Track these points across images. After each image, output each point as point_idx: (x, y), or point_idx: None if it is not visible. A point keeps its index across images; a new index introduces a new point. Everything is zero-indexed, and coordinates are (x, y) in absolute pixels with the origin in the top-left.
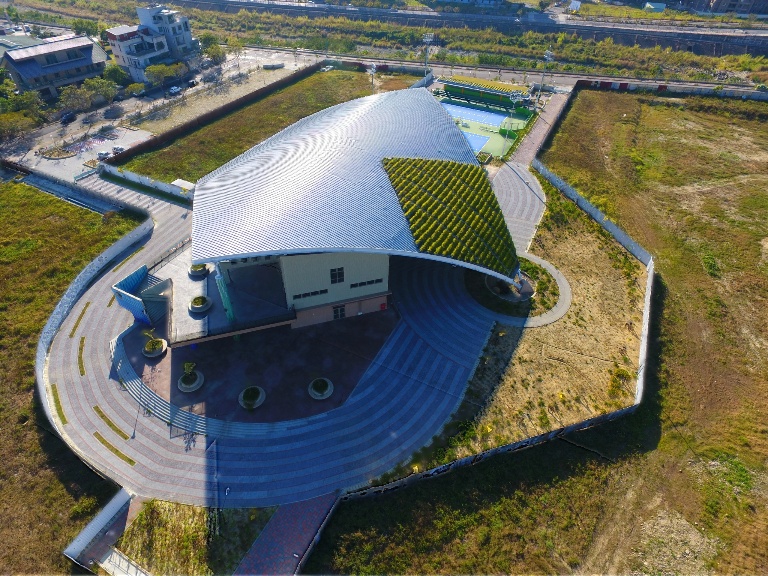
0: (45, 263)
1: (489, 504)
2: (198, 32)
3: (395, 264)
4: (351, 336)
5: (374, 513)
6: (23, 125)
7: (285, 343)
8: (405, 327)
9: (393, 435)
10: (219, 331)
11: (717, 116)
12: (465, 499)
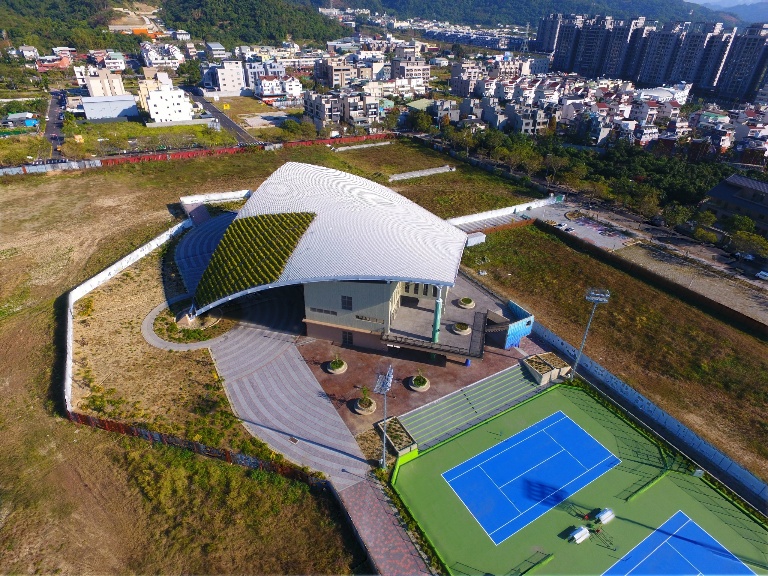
0: None
1: (137, 247)
2: None
3: None
4: None
5: None
6: None
7: None
8: None
9: None
10: None
11: None
12: None
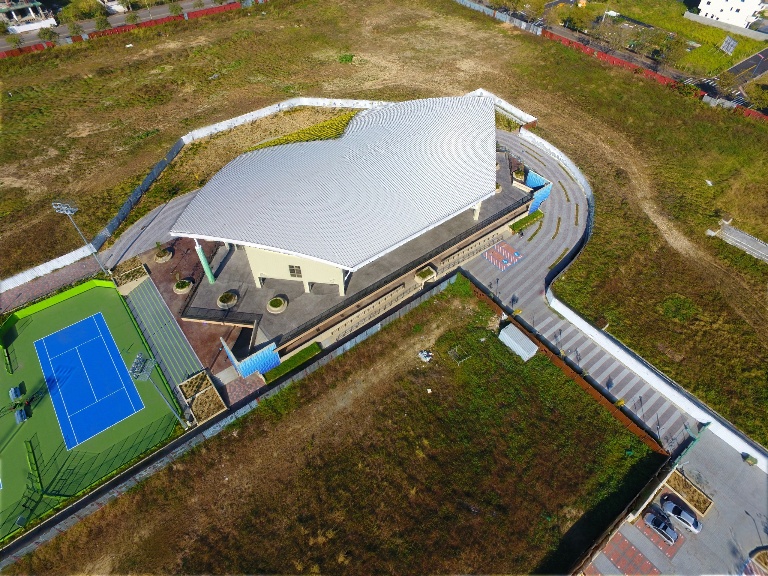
0: None
1: None
2: None
3: None
4: None
5: None
6: None
7: None
8: None
9: None
10: None
11: None
12: None
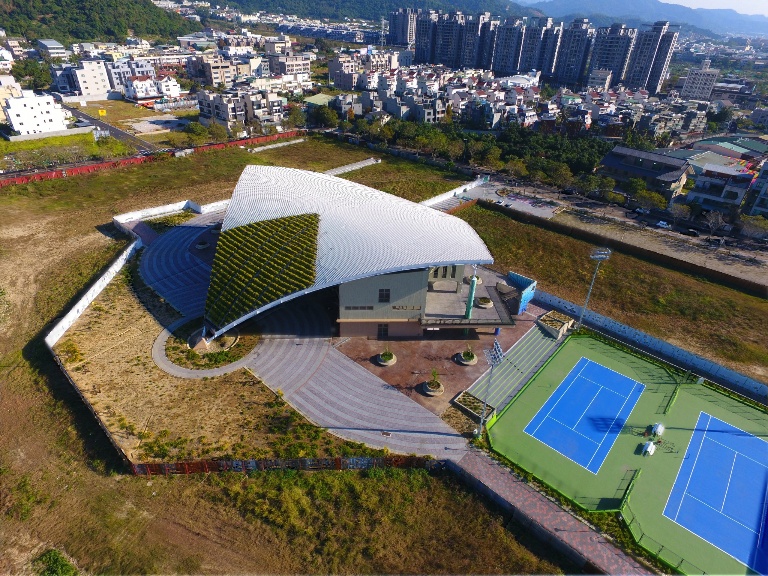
0: None
1: (90, 278)
2: None
3: None
4: None
5: None
6: None
7: None
8: None
9: None
10: None
11: None
12: None
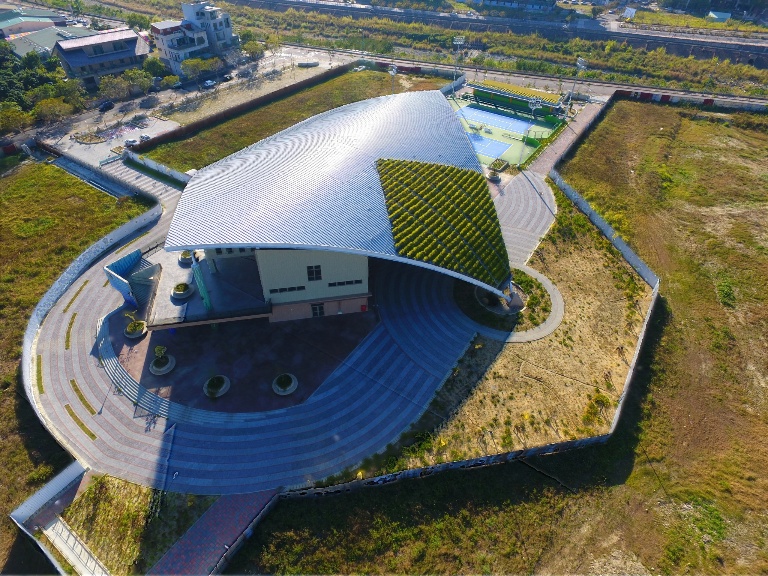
0: (57, 241)
1: (431, 520)
2: (238, 29)
3: (377, 266)
4: (326, 335)
5: (311, 514)
6: (61, 110)
7: (260, 336)
8: (382, 331)
9: (347, 438)
10: (195, 318)
11: (766, 134)
12: (406, 512)
